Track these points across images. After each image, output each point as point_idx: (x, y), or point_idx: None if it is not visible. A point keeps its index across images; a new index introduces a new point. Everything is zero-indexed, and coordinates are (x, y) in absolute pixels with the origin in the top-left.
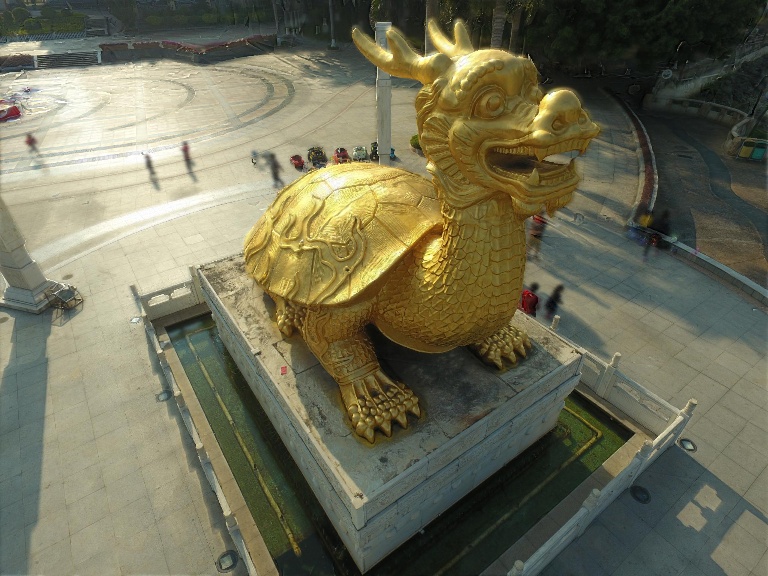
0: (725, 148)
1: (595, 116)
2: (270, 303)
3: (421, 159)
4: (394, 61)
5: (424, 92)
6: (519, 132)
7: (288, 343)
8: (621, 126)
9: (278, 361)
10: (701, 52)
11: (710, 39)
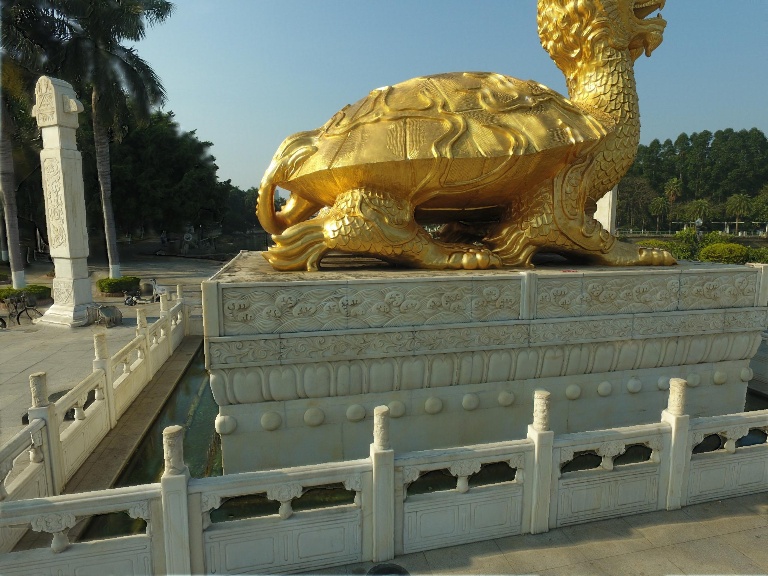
0: None
1: (169, 264)
2: (408, 270)
3: (40, 309)
4: None
5: None
6: None
7: (512, 269)
8: (203, 264)
9: None
10: (207, 218)
11: (213, 207)
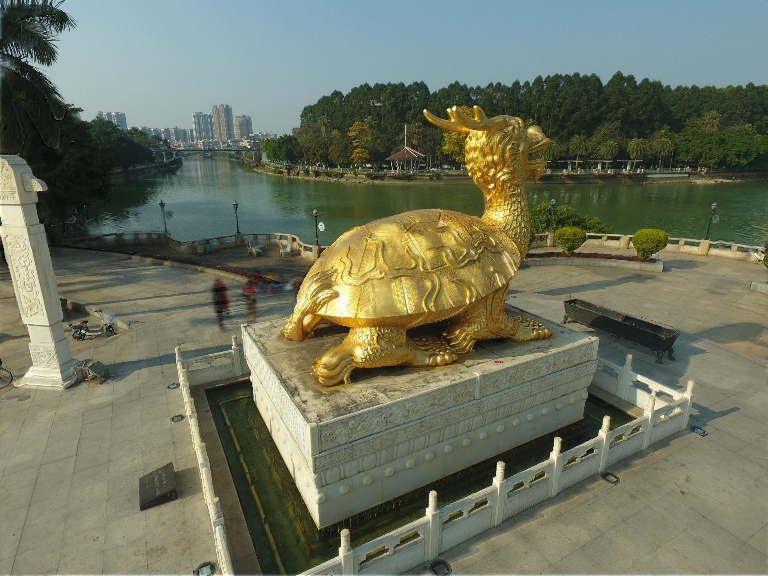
0: (182, 253)
1: (67, 260)
2: (405, 371)
3: None
4: (482, 122)
5: (505, 133)
6: (537, 142)
7: (465, 361)
8: (108, 259)
9: (488, 364)
10: (91, 197)
11: None
